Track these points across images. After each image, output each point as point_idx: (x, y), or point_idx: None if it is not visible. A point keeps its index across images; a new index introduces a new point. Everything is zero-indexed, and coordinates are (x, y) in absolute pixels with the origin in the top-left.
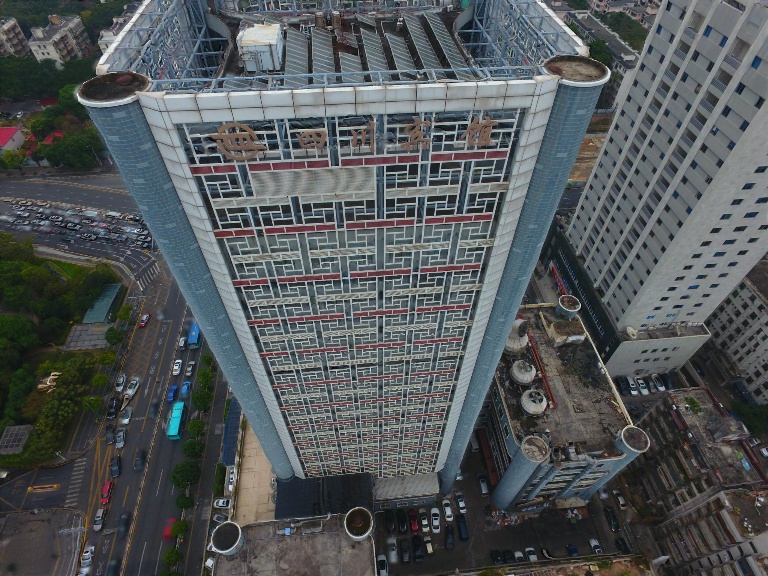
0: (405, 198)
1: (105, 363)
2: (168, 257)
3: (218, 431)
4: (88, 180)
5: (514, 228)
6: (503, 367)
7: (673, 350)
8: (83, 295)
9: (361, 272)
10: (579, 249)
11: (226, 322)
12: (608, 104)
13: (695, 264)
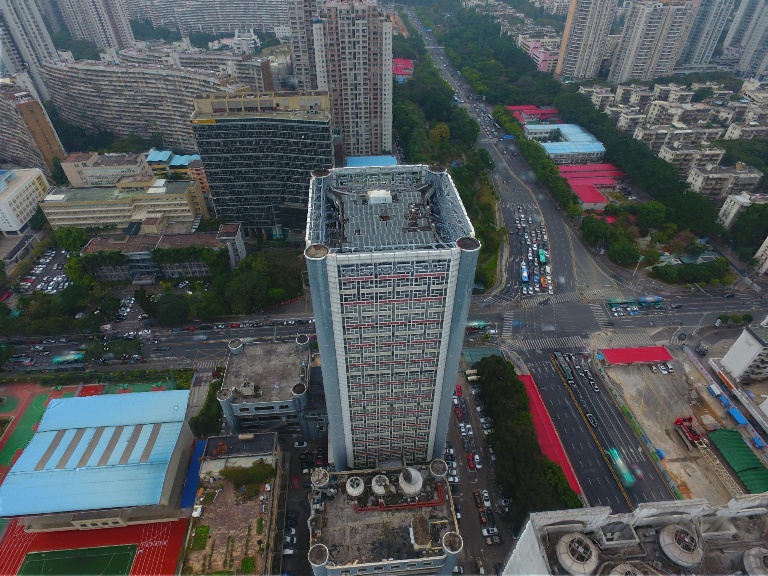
0: None
1: None
2: None
3: None
4: (580, 249)
5: None
6: (391, 478)
7: None
8: None
9: None
10: None
11: None
12: None
13: None
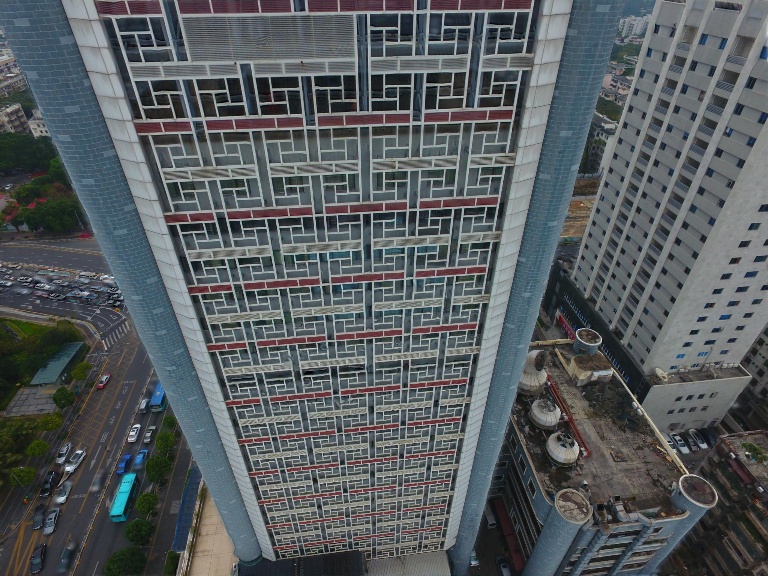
0: (397, 74)
1: (48, 428)
2: (72, 168)
3: (174, 510)
4: (67, 243)
5: (540, 140)
6: (520, 410)
7: (710, 397)
8: (37, 353)
9: (340, 205)
10: (588, 291)
11: (160, 291)
12: (594, 169)
13: (725, 287)
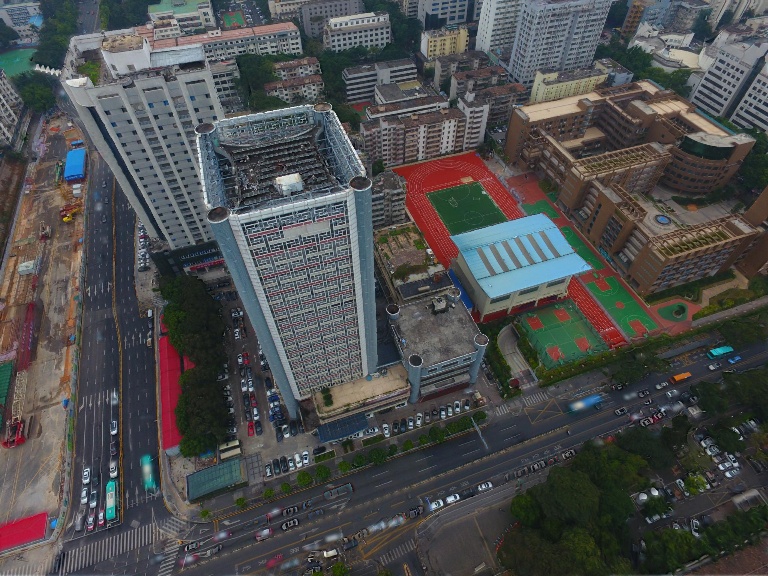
0: None
1: None
2: None
3: (340, 460)
4: None
5: None
6: None
7: None
8: None
9: None
10: (192, 241)
11: None
12: None
13: None
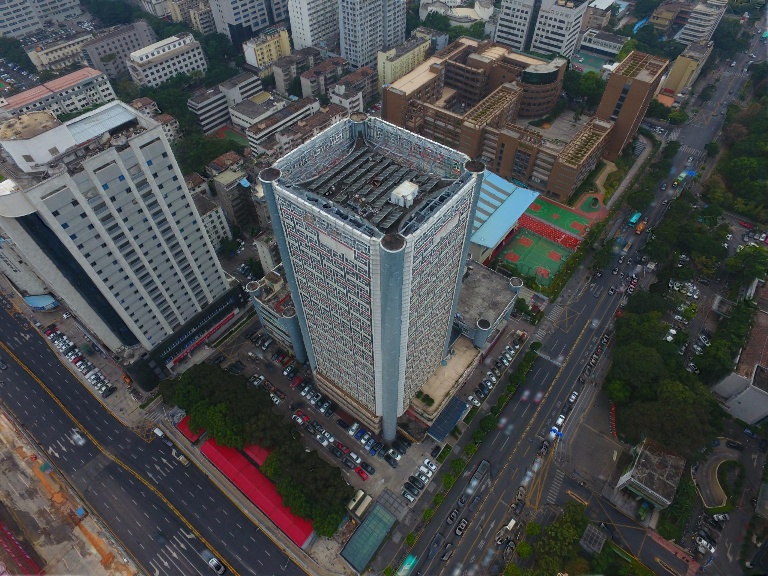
0: None
1: None
2: None
3: (458, 448)
4: None
5: None
6: None
7: None
8: None
9: None
10: (169, 331)
11: None
12: None
13: None
